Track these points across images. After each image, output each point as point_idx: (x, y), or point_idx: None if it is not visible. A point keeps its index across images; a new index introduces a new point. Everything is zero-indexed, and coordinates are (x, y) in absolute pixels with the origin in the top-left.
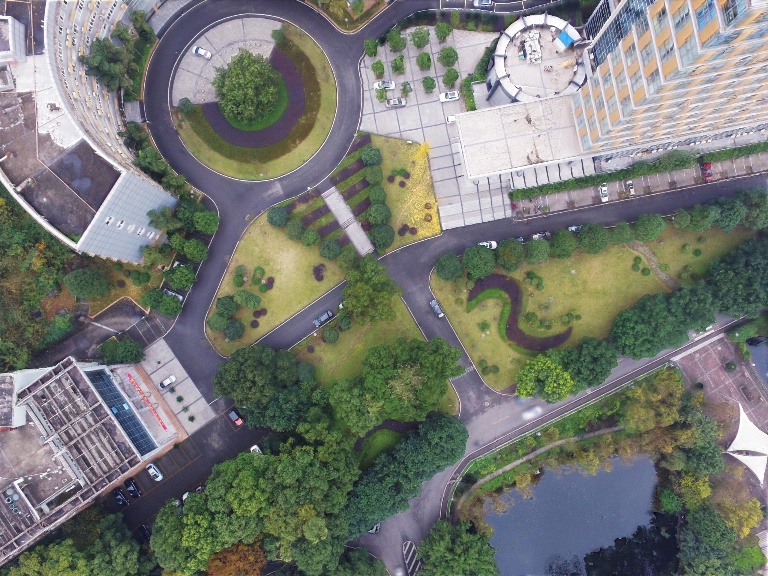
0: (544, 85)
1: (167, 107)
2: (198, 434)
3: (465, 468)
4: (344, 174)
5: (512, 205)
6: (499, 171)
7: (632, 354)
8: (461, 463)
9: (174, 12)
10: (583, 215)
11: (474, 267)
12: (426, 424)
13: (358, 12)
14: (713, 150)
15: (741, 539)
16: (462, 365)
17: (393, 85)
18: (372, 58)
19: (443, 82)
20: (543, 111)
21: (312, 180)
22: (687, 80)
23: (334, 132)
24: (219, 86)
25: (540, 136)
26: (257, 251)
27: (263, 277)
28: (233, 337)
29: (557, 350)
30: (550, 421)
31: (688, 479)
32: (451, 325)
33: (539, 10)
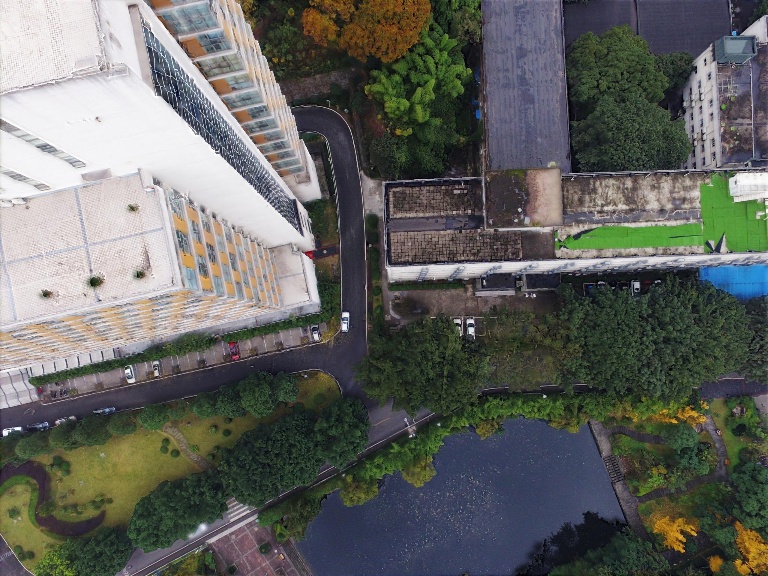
0: None
1: None
2: None
3: None
4: None
5: (37, 389)
6: None
7: (141, 547)
8: None
9: None
10: (112, 397)
11: None
12: None
13: None
14: (231, 331)
15: None
16: None
17: None
18: None
19: None
20: None
21: None
22: None
23: None
24: None
25: None
26: None
27: None
28: None
29: None
30: None
31: None
32: None
33: None
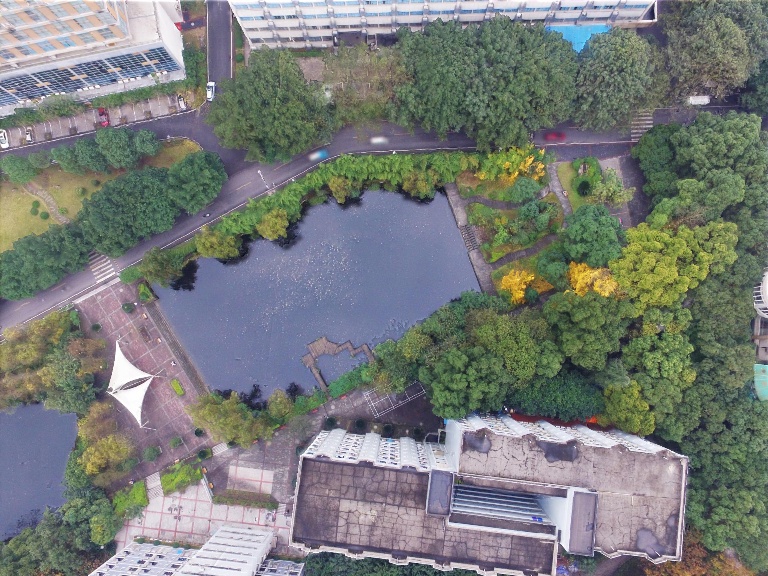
0: None
1: None
2: None
3: None
4: None
5: None
6: None
7: (3, 293)
8: None
9: None
10: None
11: None
12: None
13: None
14: None
15: (90, 476)
16: None
17: None
18: None
19: None
20: None
21: None
22: None
23: None
24: None
25: None
26: None
27: None
28: None
29: None
30: None
31: None
32: None
33: None
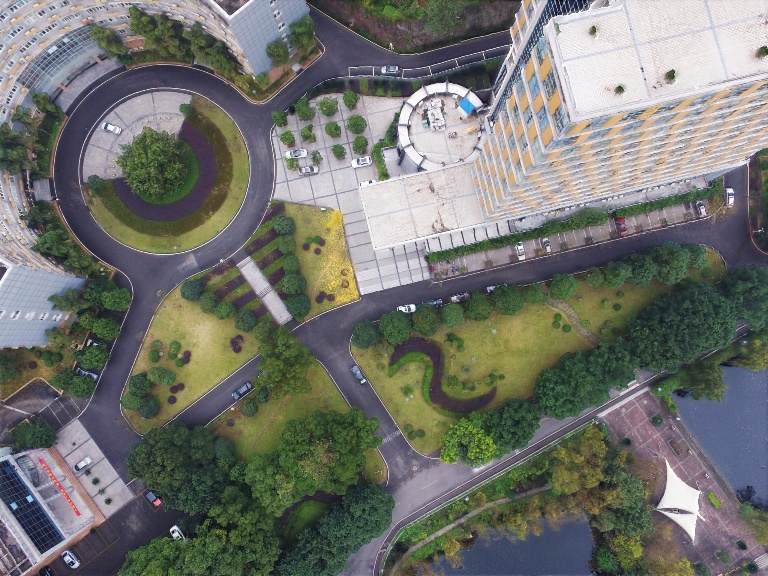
0: (449, 152)
1: (76, 185)
2: (116, 516)
3: (395, 536)
4: (258, 244)
5: (429, 267)
6: (404, 241)
7: (554, 415)
8: (391, 531)
9: (82, 89)
10: (501, 274)
11: (389, 335)
12: (350, 495)
13: (264, 85)
14: (625, 205)
15: None
16: (386, 431)
17: (305, 153)
18: (283, 127)
19: (353, 149)
20: (446, 180)
21: (227, 251)
22: (549, 171)
23: (248, 202)
24: (123, 165)
25: (444, 205)
26: (172, 325)
27: (179, 351)
28: (147, 416)
29: (480, 413)
30: (479, 484)
31: (620, 538)
32: (374, 390)
33: (446, 75)
